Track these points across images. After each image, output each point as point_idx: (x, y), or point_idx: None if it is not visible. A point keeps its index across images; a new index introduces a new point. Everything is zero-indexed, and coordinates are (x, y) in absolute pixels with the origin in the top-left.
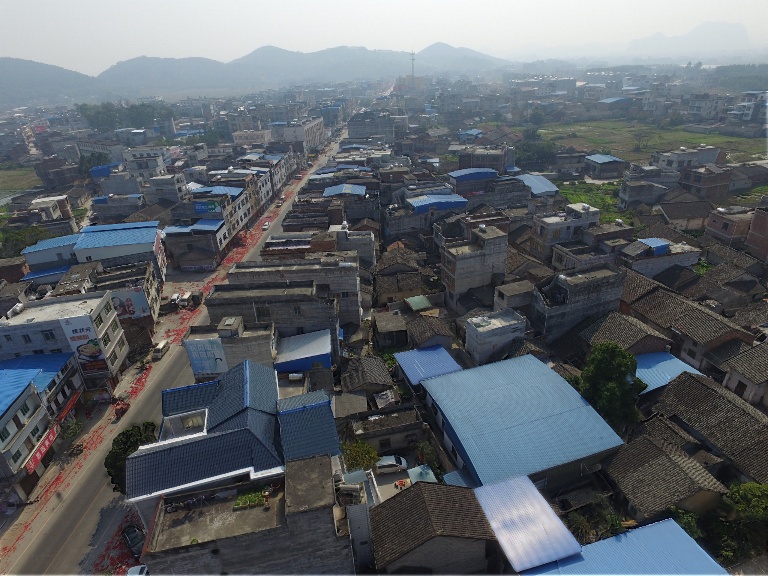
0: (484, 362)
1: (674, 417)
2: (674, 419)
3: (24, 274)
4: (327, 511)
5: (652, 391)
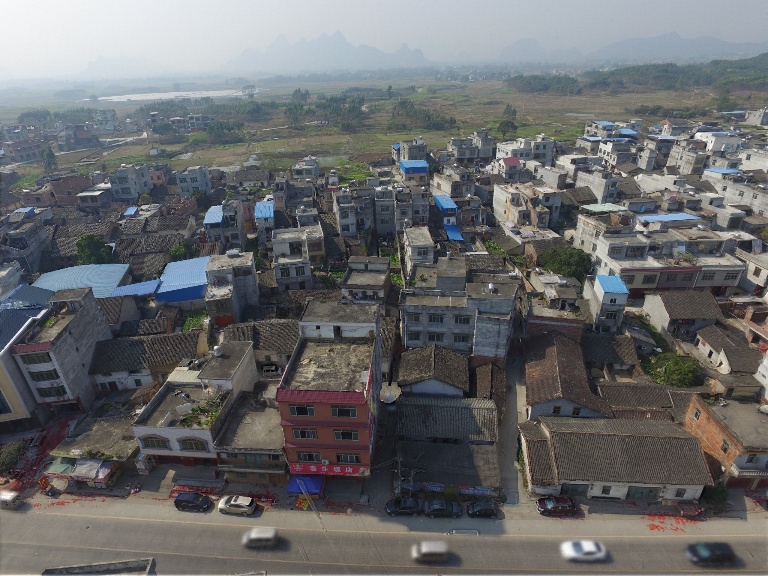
0: None
1: (131, 255)
2: None
3: None
4: (91, 293)
5: (113, 253)
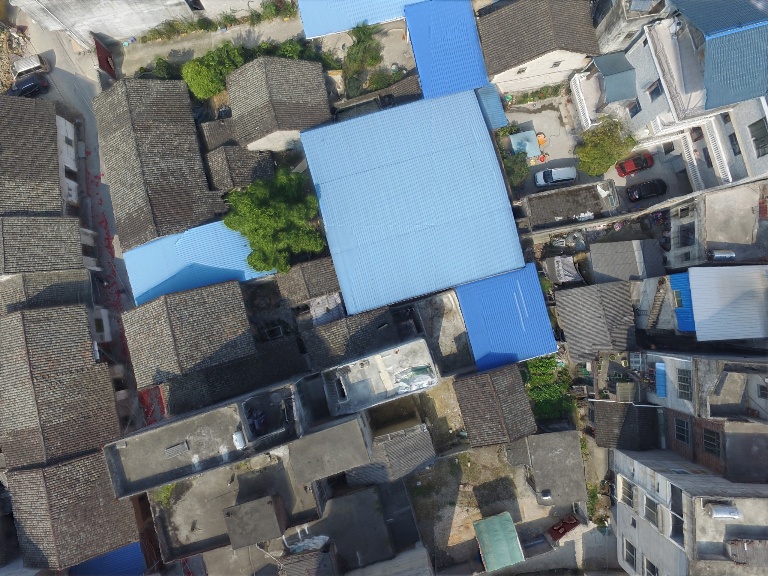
0: (412, 337)
1: (213, 188)
2: (214, 188)
3: None
4: None
5: None
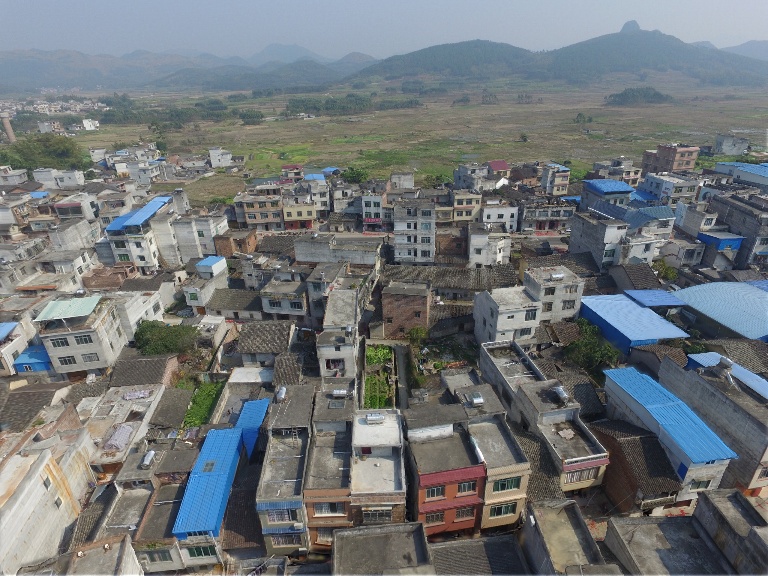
0: None
1: None
2: None
3: None
4: None
5: None
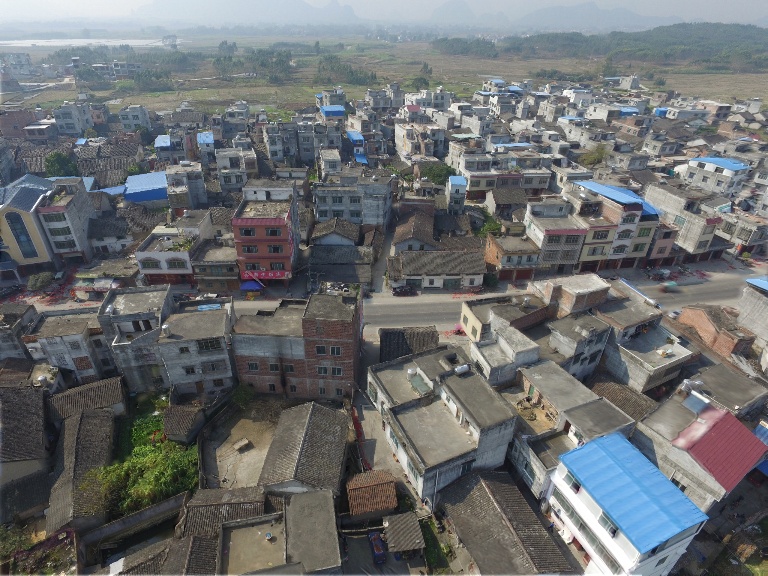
0: None
1: (91, 173)
2: None
3: None
4: None
5: None
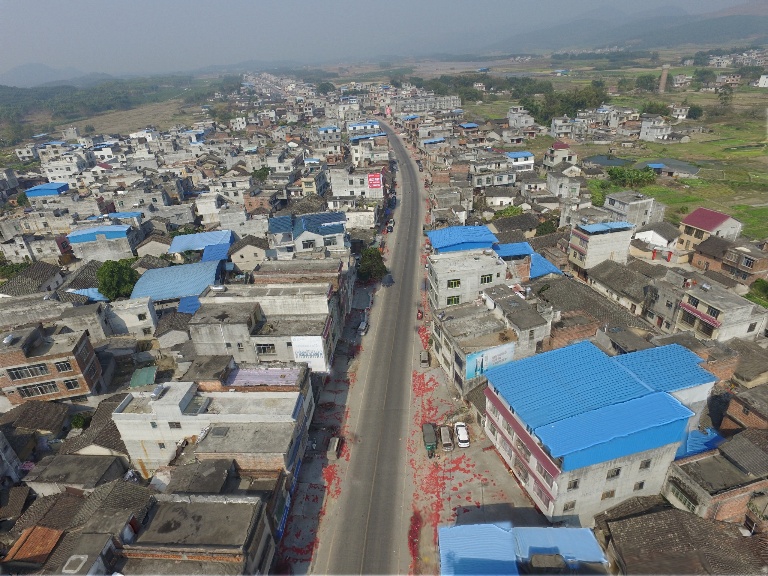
0: None
1: None
2: None
3: (730, 408)
4: None
5: None
